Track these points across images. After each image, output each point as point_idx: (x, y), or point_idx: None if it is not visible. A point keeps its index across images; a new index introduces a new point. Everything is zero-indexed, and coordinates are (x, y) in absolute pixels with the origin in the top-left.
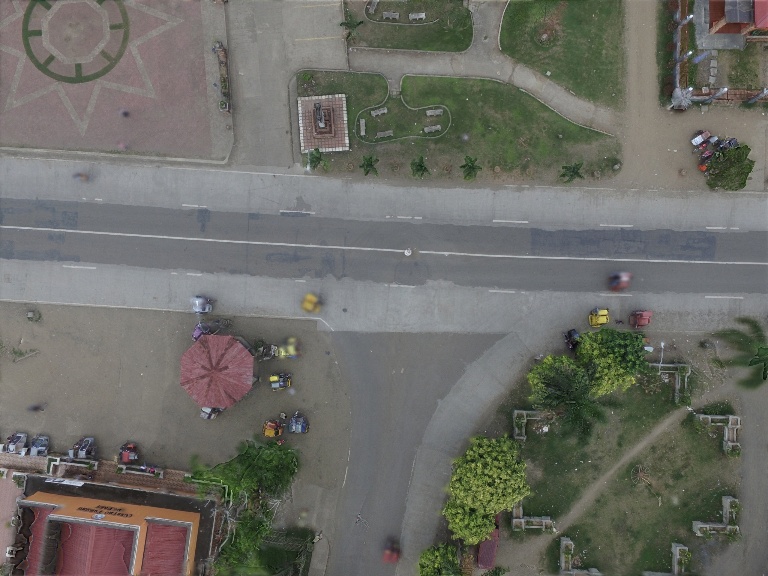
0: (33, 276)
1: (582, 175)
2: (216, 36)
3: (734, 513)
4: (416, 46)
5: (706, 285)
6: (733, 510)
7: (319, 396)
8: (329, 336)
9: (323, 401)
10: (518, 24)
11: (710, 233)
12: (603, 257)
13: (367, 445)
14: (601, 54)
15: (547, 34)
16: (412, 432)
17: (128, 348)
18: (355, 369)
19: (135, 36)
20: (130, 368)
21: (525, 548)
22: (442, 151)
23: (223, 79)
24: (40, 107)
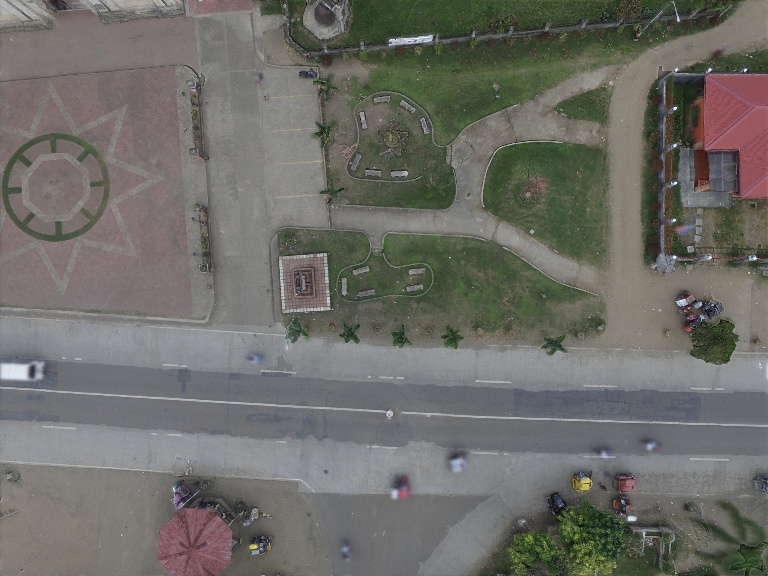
0: (12, 436)
1: (566, 335)
2: (197, 194)
3: None
4: (398, 203)
5: (691, 447)
6: None
7: (300, 558)
8: (310, 498)
9: (304, 563)
10: (501, 181)
11: (695, 394)
12: (587, 418)
13: None
14: (585, 212)
15: (531, 192)
16: None
17: (108, 508)
18: (336, 531)
19: (115, 194)
20: (110, 529)
21: None
22: (424, 310)
23: (204, 239)
24: (20, 265)
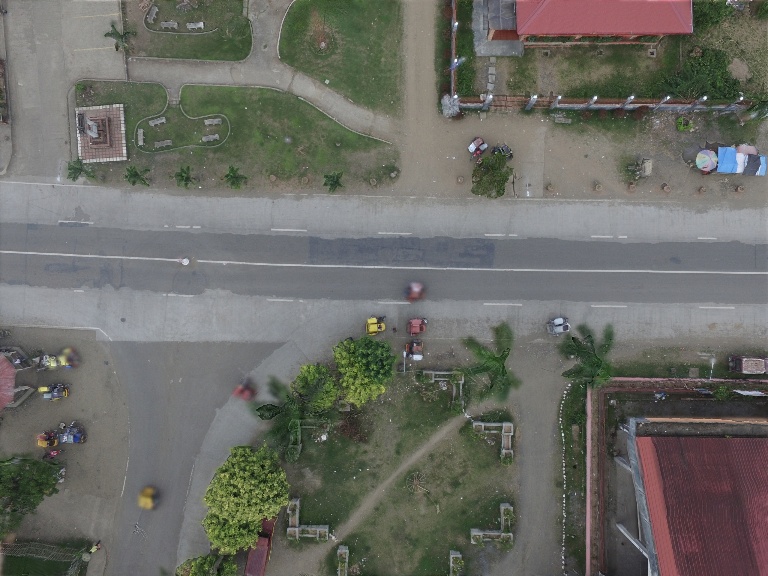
0: None
1: (360, 183)
2: None
3: (509, 520)
4: (195, 55)
5: (484, 292)
6: (508, 517)
7: (98, 406)
8: (108, 346)
9: (102, 411)
10: (297, 32)
11: (489, 240)
12: (381, 265)
13: (145, 455)
14: (380, 62)
15: (326, 42)
16: (190, 441)
17: None
18: (133, 379)
19: None
20: None
21: (305, 556)
22: (220, 160)
23: None
24: None
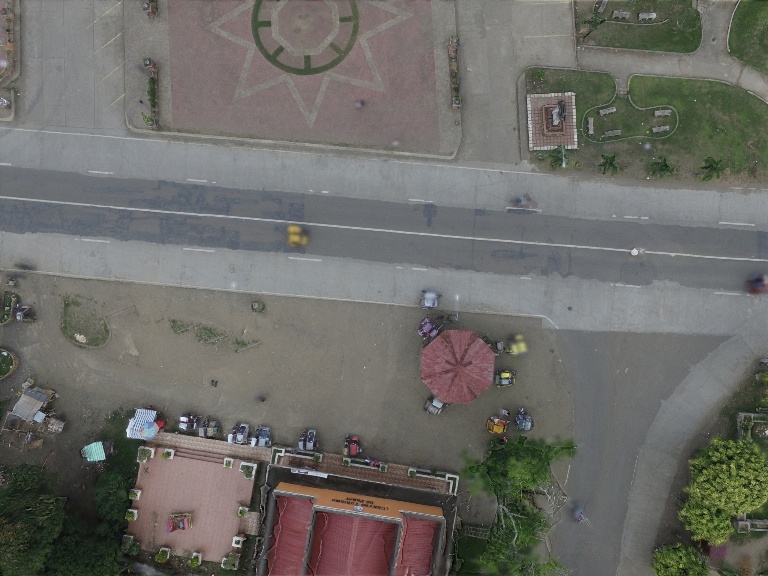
0: (258, 267)
1: None
2: (446, 31)
3: None
4: (645, 46)
5: None
6: None
7: (542, 394)
8: (553, 334)
9: (546, 399)
10: (747, 26)
11: None
12: None
13: (590, 444)
14: None
15: None
16: (635, 432)
17: (351, 341)
18: (579, 368)
19: (365, 29)
20: (353, 361)
21: (745, 551)
22: (670, 152)
23: (455, 74)
24: (268, 98)
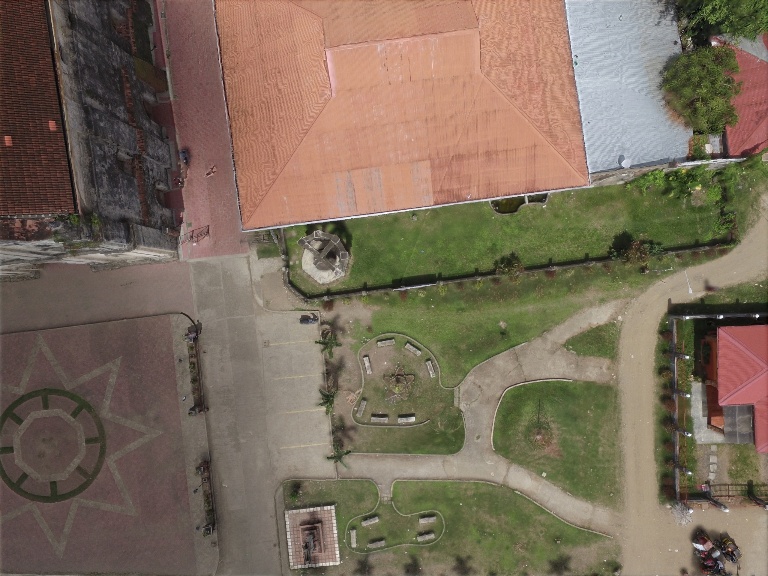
0: None
1: None
2: (197, 448)
3: None
4: (406, 449)
5: None
6: None
7: None
8: None
9: None
10: (511, 423)
11: None
12: None
13: None
14: (597, 452)
15: (541, 433)
16: None
17: None
18: None
19: (112, 450)
20: None
21: None
22: (436, 560)
23: (206, 498)
24: (14, 529)
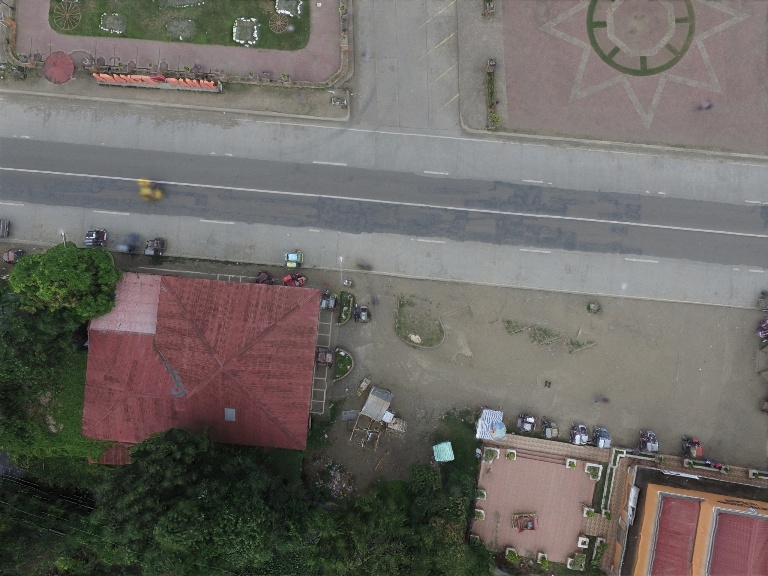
0: (594, 268)
1: None
2: None
3: None
4: None
5: None
6: None
7: None
8: None
9: None
10: None
11: None
12: None
13: None
14: None
15: None
16: None
17: (686, 343)
18: None
19: (701, 30)
20: (688, 363)
21: None
22: None
23: None
24: (605, 99)
